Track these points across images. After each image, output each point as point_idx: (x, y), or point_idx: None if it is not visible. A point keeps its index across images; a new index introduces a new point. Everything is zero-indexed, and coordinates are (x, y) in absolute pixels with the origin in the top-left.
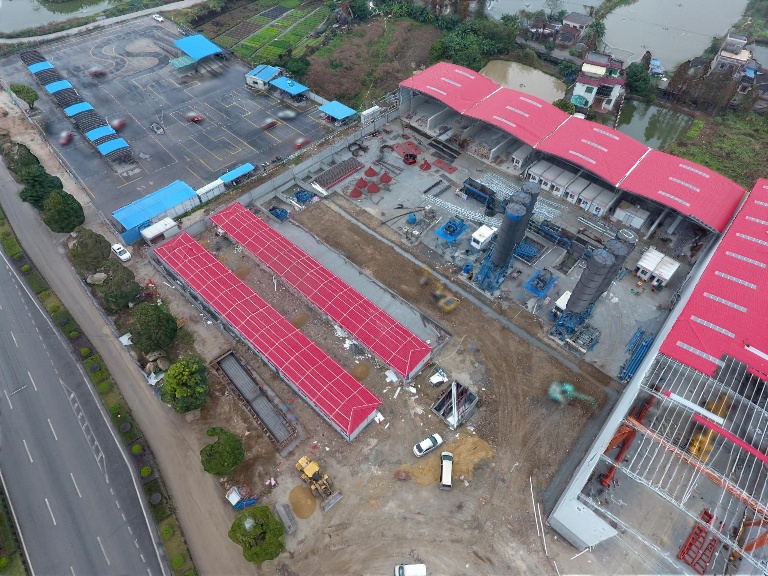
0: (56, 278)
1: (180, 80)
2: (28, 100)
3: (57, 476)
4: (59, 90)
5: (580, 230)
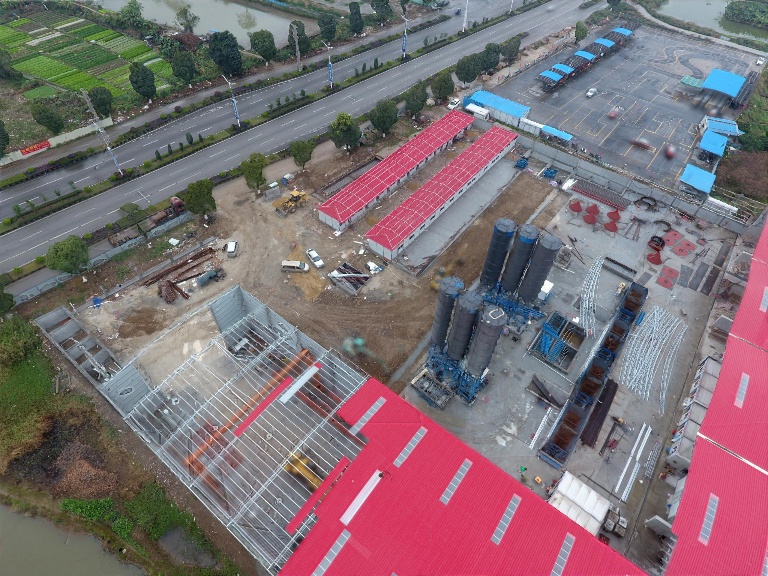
0: (428, 90)
1: (670, 90)
2: (576, 35)
3: (305, 120)
4: (600, 43)
5: (618, 418)
